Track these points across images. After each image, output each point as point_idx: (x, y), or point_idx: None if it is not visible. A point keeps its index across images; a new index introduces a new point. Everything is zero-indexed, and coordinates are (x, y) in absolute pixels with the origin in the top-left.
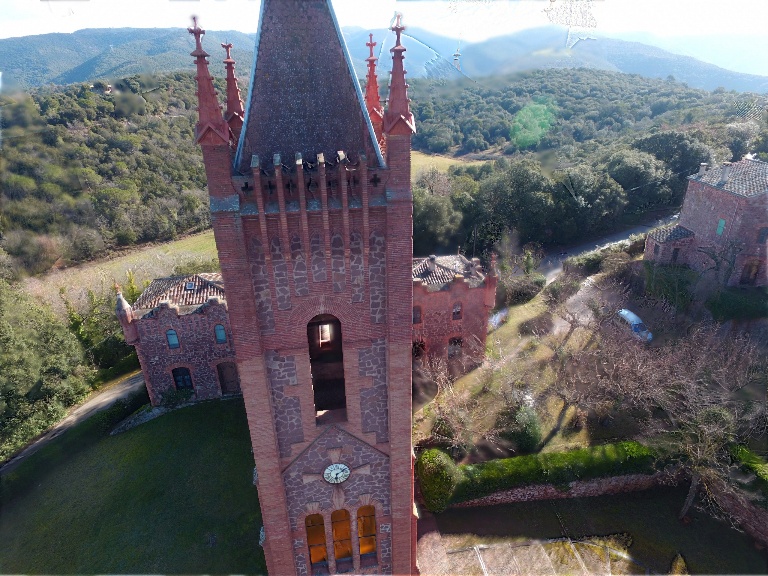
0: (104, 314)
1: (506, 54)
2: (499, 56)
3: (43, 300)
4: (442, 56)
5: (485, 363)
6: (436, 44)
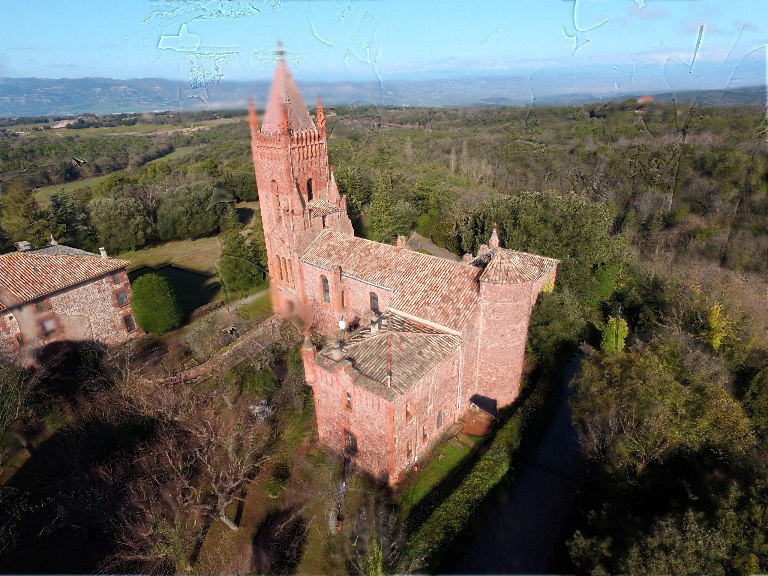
0: (724, 339)
1: (250, 103)
2: (255, 104)
3: (710, 290)
4: (299, 100)
5: (319, 441)
6: (305, 91)
